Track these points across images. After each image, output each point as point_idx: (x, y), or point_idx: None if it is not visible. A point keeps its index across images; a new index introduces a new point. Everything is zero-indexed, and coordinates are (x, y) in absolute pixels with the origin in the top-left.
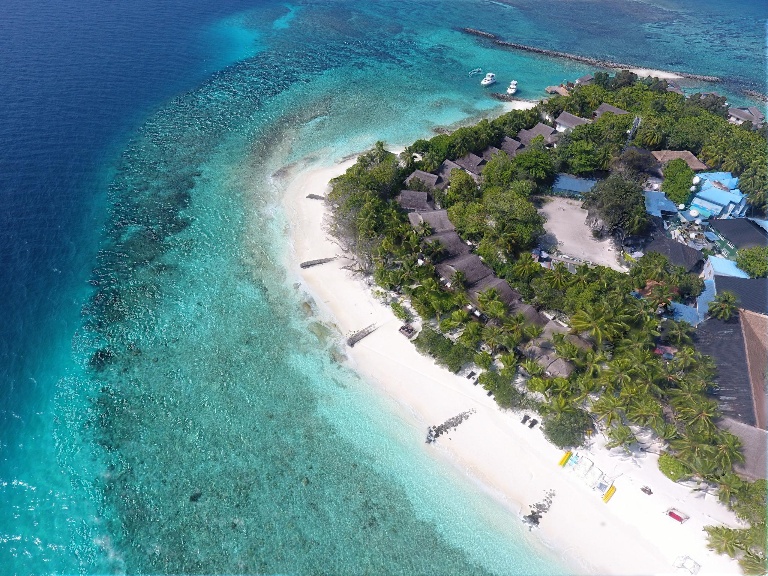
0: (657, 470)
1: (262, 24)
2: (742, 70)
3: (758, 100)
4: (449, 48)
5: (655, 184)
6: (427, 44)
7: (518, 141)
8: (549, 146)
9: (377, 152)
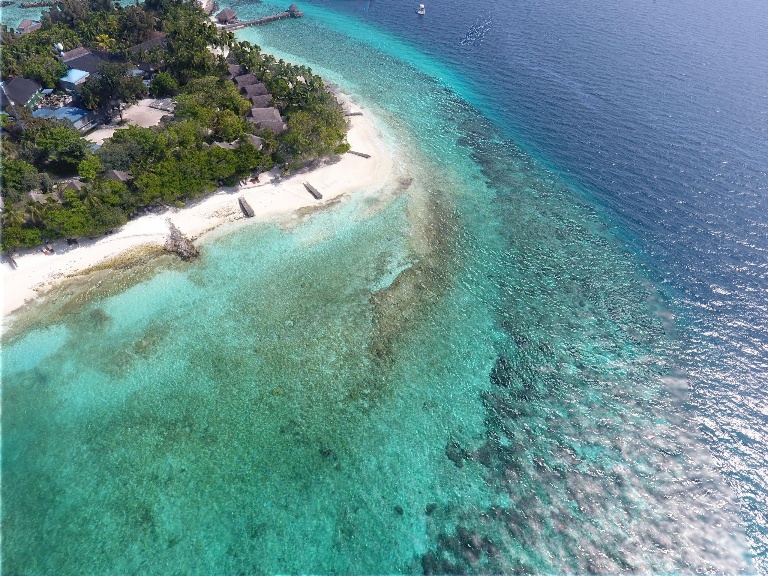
0: None
1: None
2: None
3: None
4: None
5: None
6: None
7: None
8: None
9: None
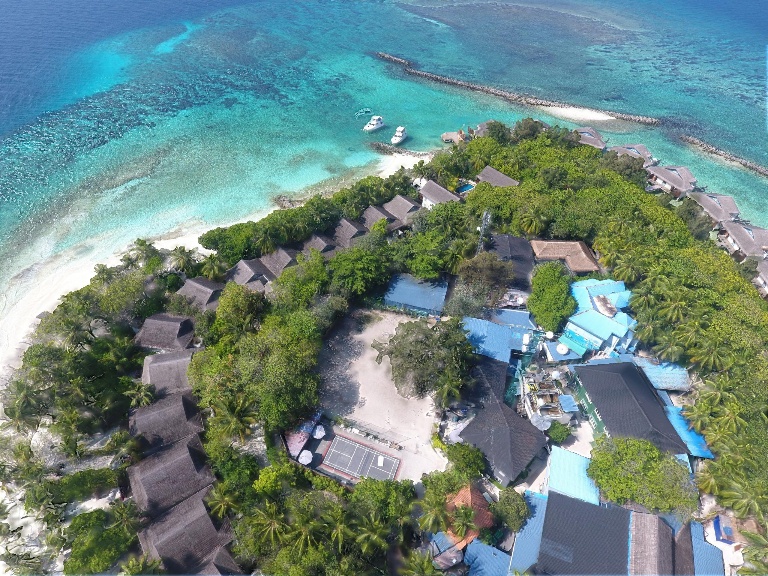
0: None
1: (142, 48)
2: (689, 107)
3: (699, 150)
4: (349, 79)
5: (519, 298)
6: (325, 73)
7: (362, 223)
8: (404, 228)
9: (138, 253)
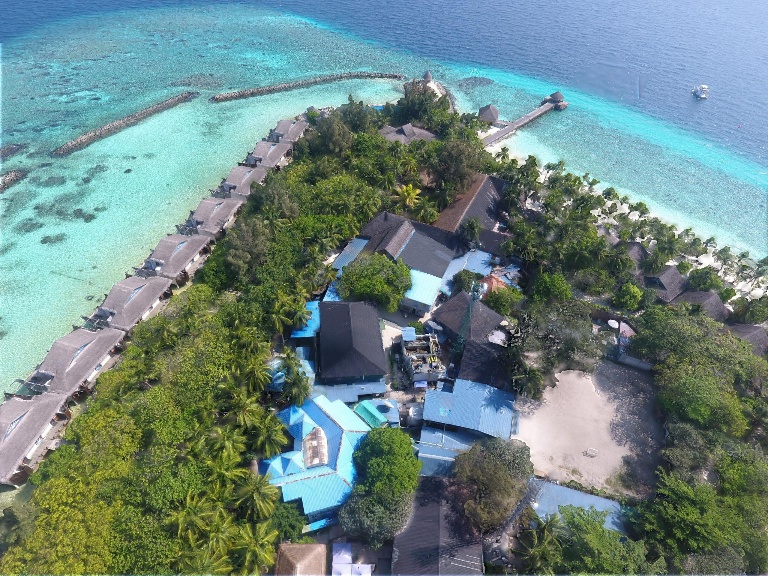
0: (527, 197)
1: None
2: None
3: None
4: None
5: None
6: None
7: None
8: None
9: None
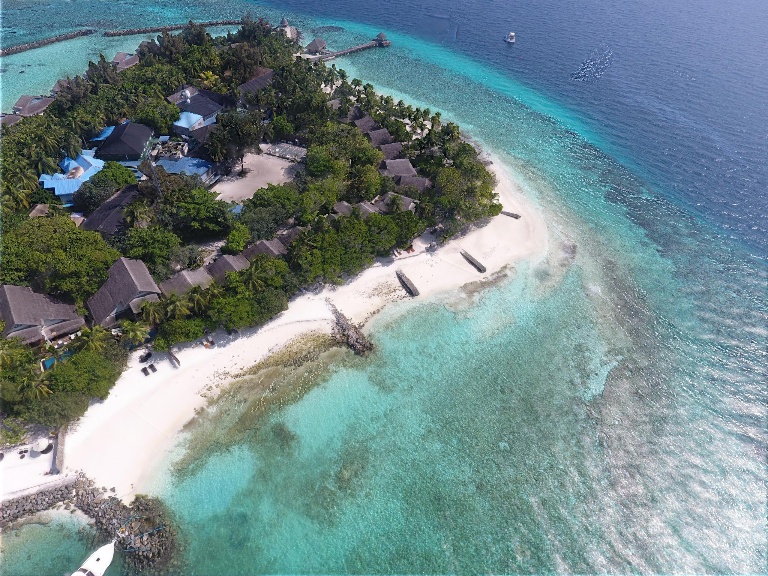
0: None
1: None
2: None
3: None
4: None
5: None
6: None
7: None
8: None
9: None
